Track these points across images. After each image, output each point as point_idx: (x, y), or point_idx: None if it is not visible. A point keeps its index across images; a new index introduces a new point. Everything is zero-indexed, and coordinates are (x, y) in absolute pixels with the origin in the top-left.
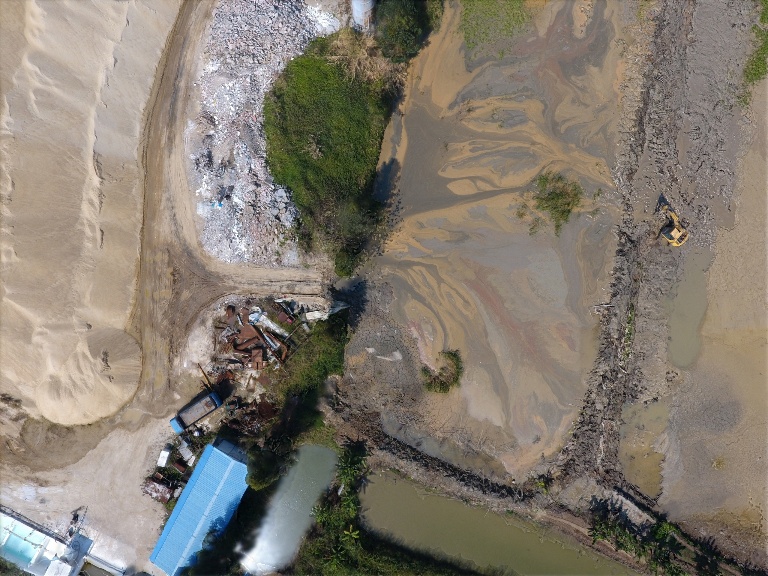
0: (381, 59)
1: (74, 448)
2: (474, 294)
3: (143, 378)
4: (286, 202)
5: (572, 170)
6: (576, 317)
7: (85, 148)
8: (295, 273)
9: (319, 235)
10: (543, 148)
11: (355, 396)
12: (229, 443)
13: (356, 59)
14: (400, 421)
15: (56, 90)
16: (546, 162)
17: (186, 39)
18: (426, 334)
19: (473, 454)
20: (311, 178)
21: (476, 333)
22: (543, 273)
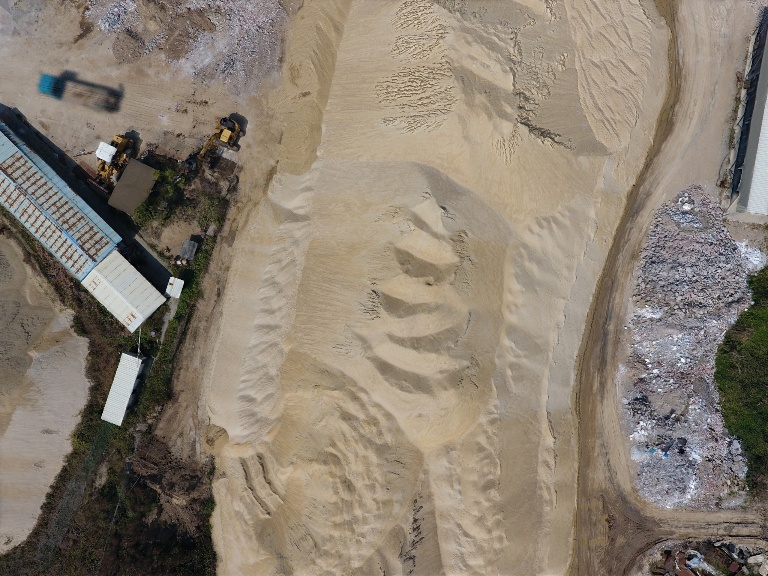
0: None
1: None
2: None
3: None
4: (740, 453)
5: None
6: None
7: (539, 409)
8: (732, 515)
9: None
10: None
11: None
12: None
13: None
14: None
15: (524, 360)
16: None
17: (614, 281)
18: None
19: None
20: None
21: None
22: None
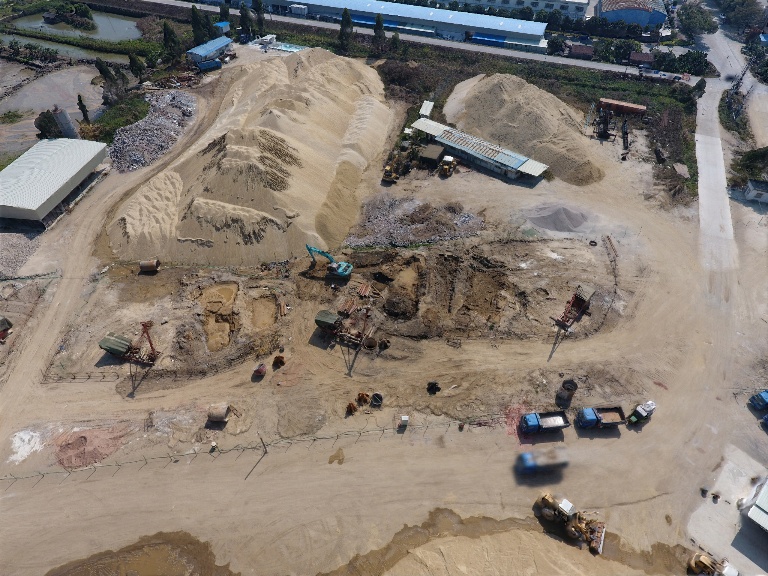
0: None
1: None
2: None
3: None
4: None
5: None
6: None
7: None
8: None
9: None
10: (5, 130)
11: None
12: None
13: None
14: None
15: None
16: None
17: (185, 145)
18: None
19: None
20: None
21: None
22: None
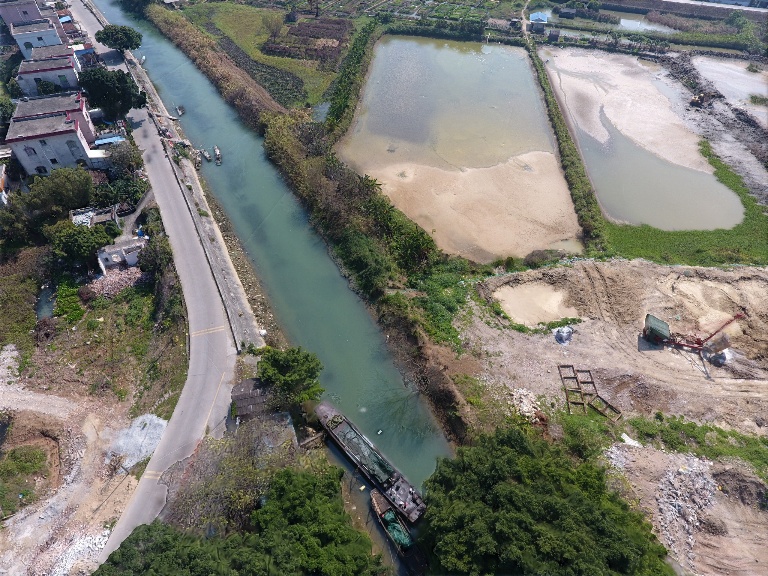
0: None
1: None
2: (766, 82)
3: None
4: None
5: None
6: None
7: None
8: None
9: None
10: None
11: None
12: None
13: None
14: None
15: None
16: None
17: None
18: None
19: None
20: None
21: None
22: None
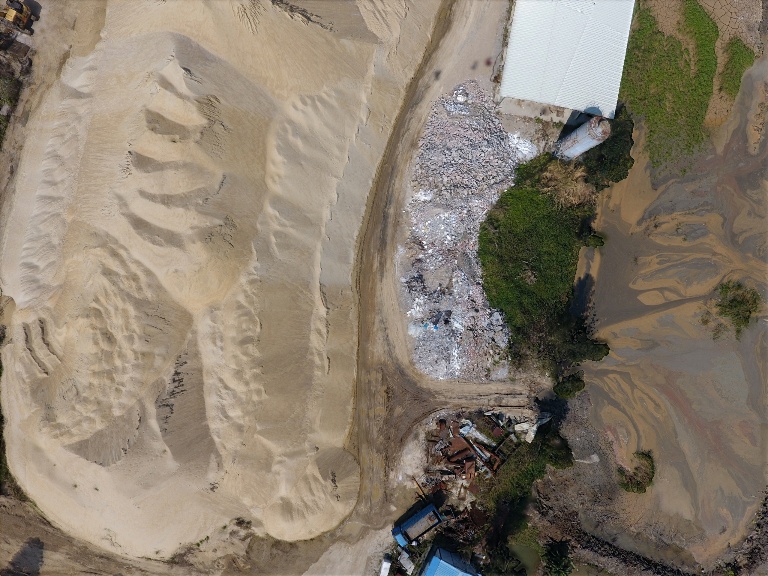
0: (581, 184)
1: (297, 562)
2: (664, 398)
3: (361, 492)
4: (501, 324)
5: (750, 278)
6: (757, 415)
7: (312, 280)
8: (502, 387)
9: (530, 353)
10: (723, 258)
11: (556, 498)
12: (445, 551)
13: (564, 189)
14: (597, 519)
15: (291, 230)
16: (726, 271)
17: (394, 168)
18: (621, 437)
19: (665, 547)
20: (526, 302)
21: (667, 434)
22: (726, 375)
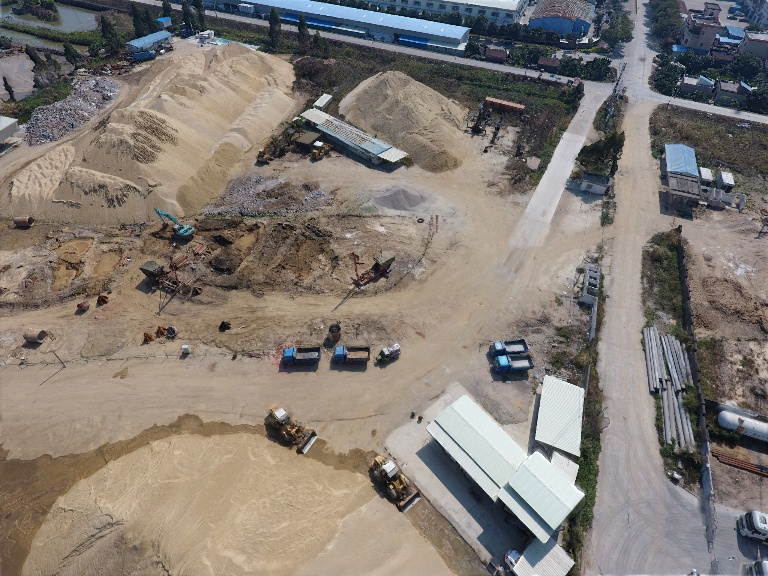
0: None
1: None
2: None
3: None
4: None
5: None
6: None
7: None
8: None
9: None
10: None
11: None
12: None
13: None
14: None
15: None
16: None
17: None
18: None
19: None
20: None
21: None
22: None
